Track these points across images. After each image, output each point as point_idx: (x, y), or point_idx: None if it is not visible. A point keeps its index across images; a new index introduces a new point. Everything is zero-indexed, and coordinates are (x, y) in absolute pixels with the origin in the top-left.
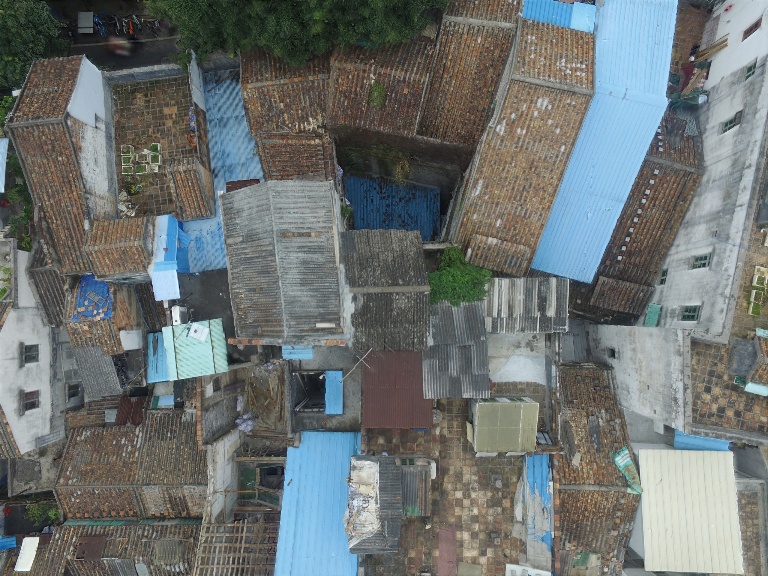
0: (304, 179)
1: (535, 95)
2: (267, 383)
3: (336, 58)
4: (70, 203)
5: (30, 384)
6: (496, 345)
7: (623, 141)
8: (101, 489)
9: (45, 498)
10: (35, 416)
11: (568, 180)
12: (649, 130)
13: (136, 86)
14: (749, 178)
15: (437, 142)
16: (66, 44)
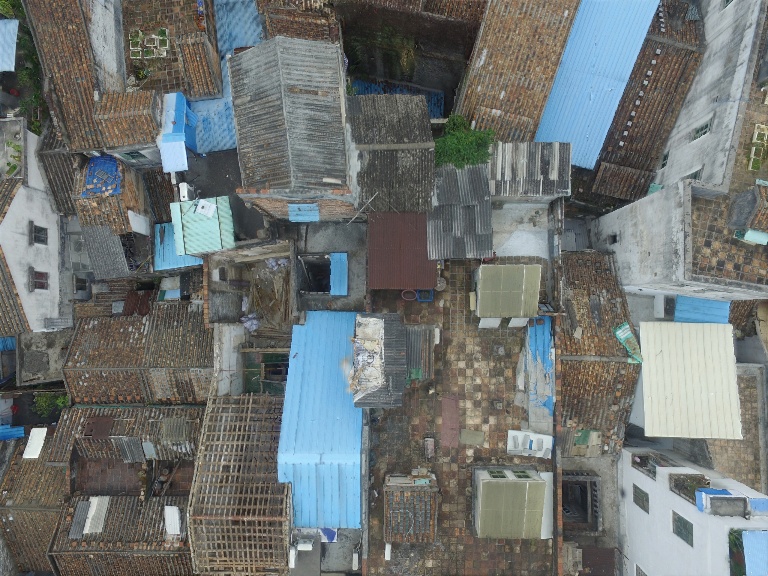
0: None
1: None
2: (272, 285)
3: None
4: (80, 75)
5: (39, 264)
6: (499, 221)
7: (626, 16)
8: (109, 372)
9: (53, 388)
10: (44, 297)
11: (571, 59)
12: (651, 4)
13: None
14: (750, 36)
15: (442, 18)
16: None
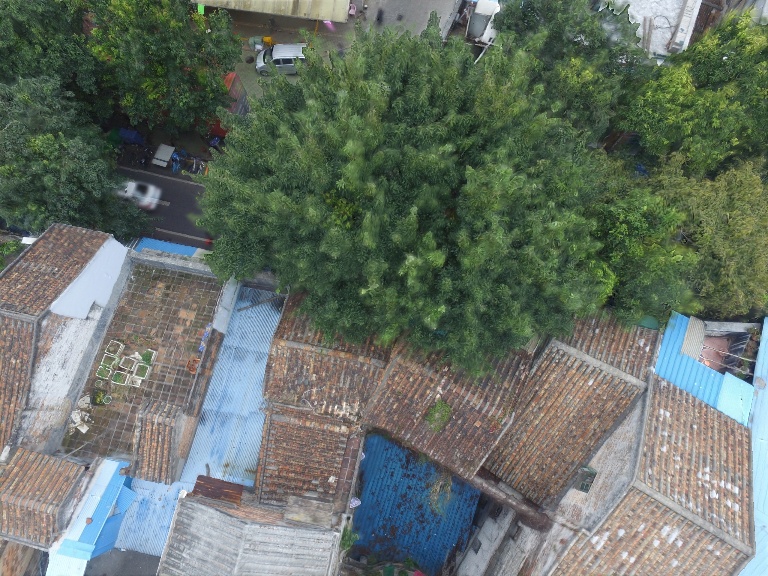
0: (303, 508)
1: (662, 519)
2: None
3: (401, 349)
4: (1, 415)
5: None
6: None
7: None
8: None
9: None
10: None
11: None
12: None
13: (162, 273)
14: None
15: (500, 496)
16: (123, 183)
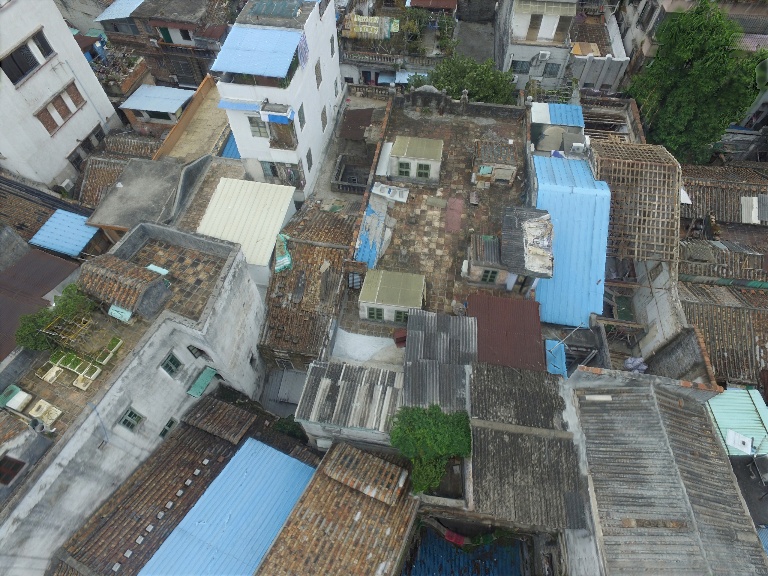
0: None
1: None
2: None
3: None
4: None
5: None
6: None
7: None
8: None
9: None
10: None
11: None
12: None
13: None
14: (28, 500)
15: None
16: None
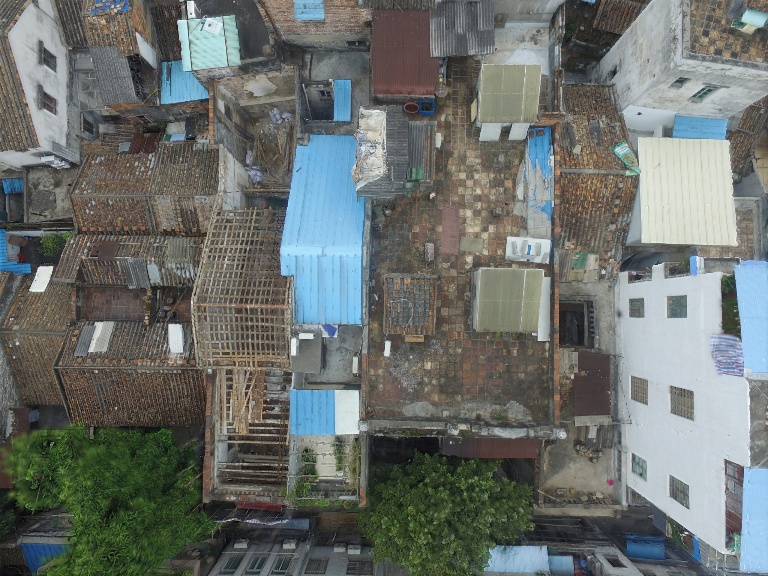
0: None
1: None
2: (276, 140)
3: None
4: None
5: (48, 87)
6: (501, 39)
7: None
8: (115, 199)
9: (59, 226)
10: (52, 121)
11: None
12: None
13: None
14: None
15: None
16: None
